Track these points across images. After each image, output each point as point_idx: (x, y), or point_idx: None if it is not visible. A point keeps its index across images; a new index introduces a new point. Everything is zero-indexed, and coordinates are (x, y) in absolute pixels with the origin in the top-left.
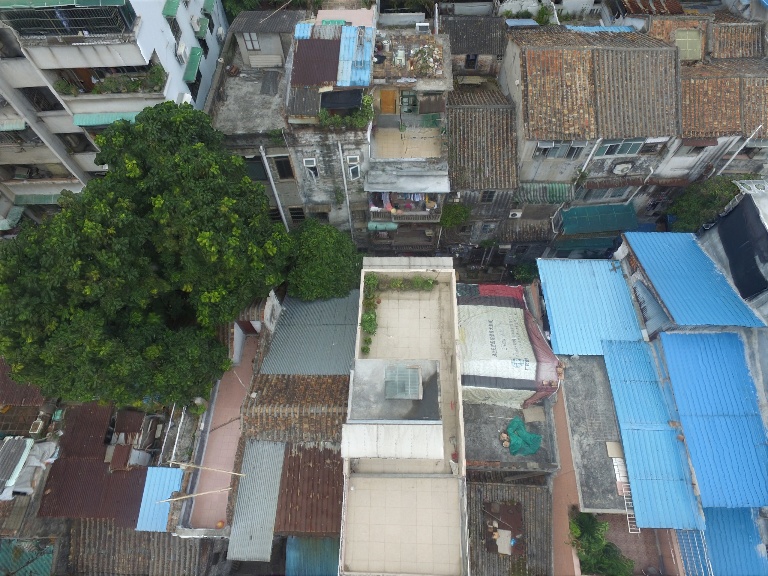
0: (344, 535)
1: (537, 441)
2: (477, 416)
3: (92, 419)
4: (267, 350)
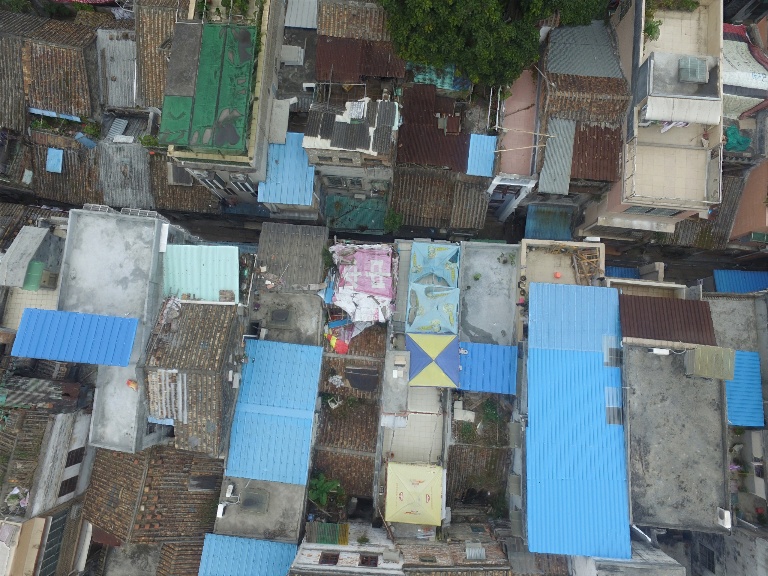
0: None
1: (747, 142)
2: None
3: (422, 98)
4: None
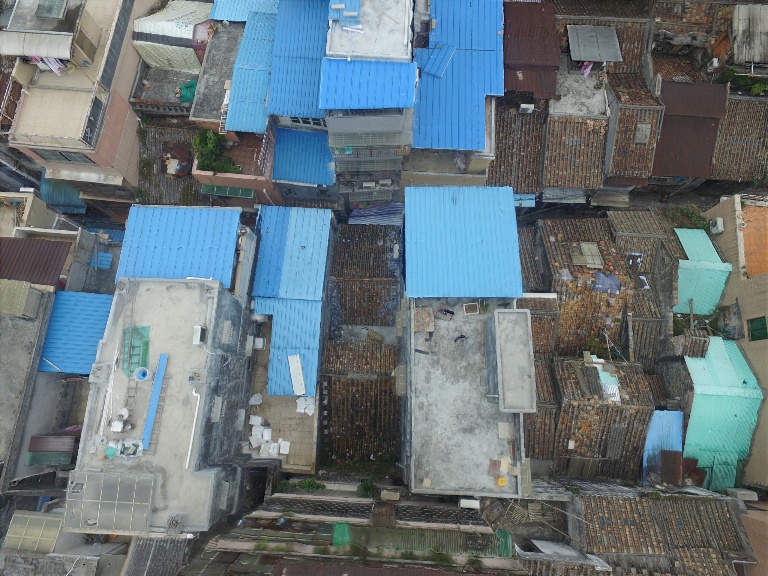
0: (15, 120)
1: None
2: (164, 78)
3: None
4: None
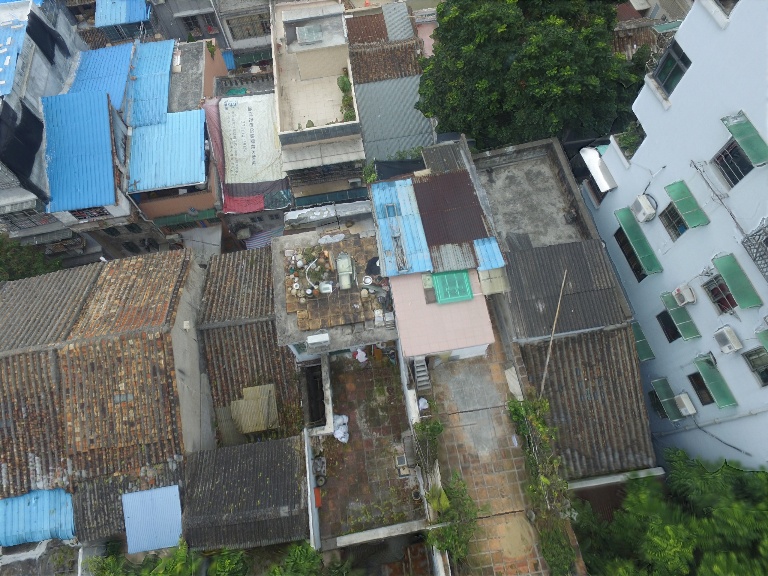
0: None
1: None
2: None
3: None
4: None
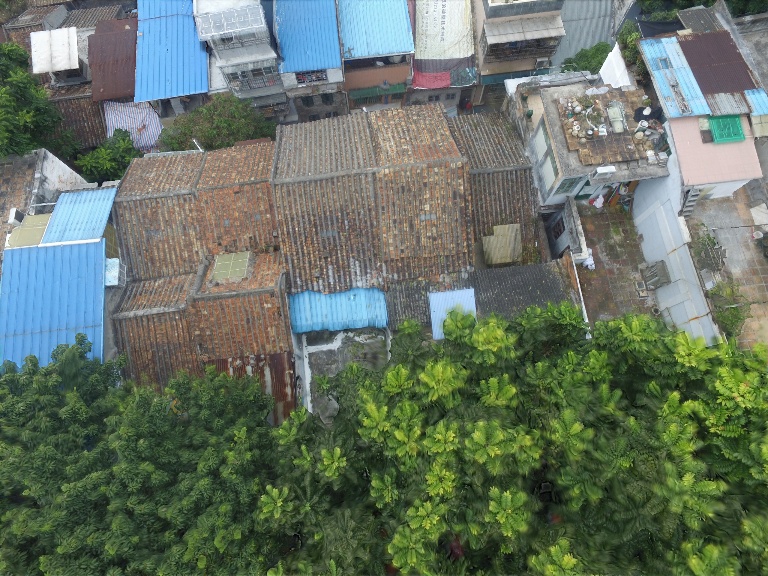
0: None
1: None
2: None
3: None
4: None
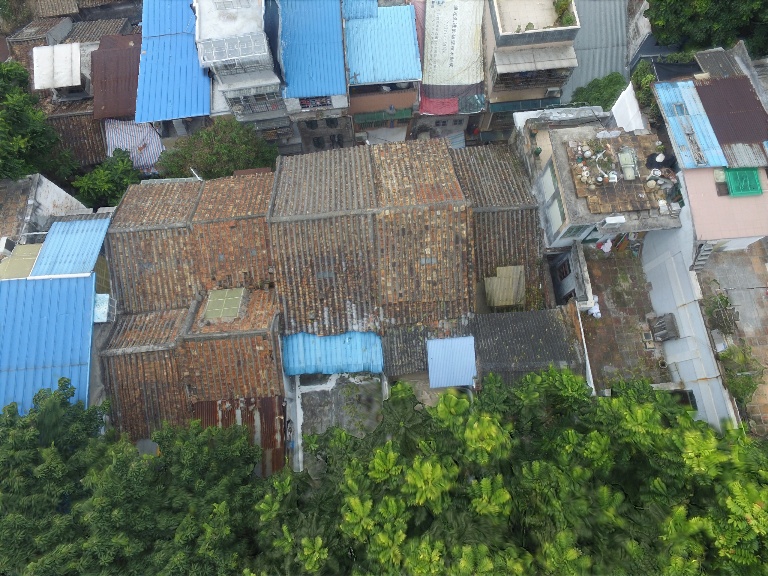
0: None
1: None
2: None
3: None
4: (630, 8)
